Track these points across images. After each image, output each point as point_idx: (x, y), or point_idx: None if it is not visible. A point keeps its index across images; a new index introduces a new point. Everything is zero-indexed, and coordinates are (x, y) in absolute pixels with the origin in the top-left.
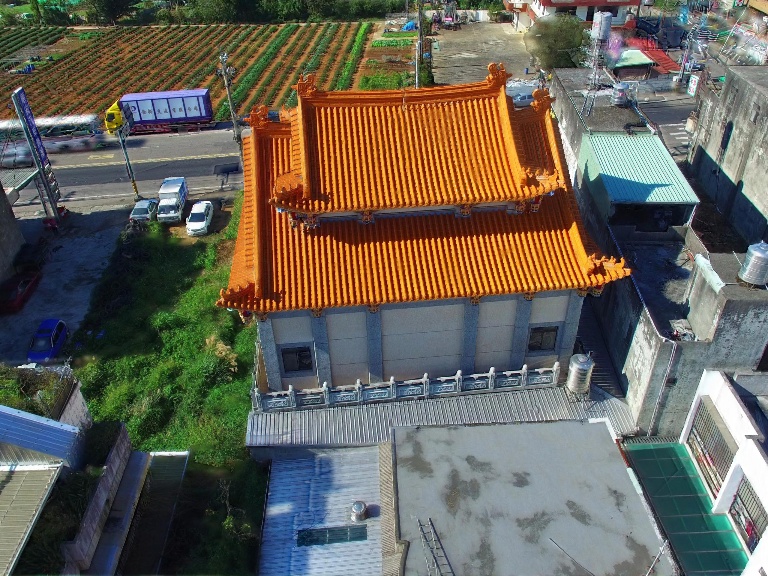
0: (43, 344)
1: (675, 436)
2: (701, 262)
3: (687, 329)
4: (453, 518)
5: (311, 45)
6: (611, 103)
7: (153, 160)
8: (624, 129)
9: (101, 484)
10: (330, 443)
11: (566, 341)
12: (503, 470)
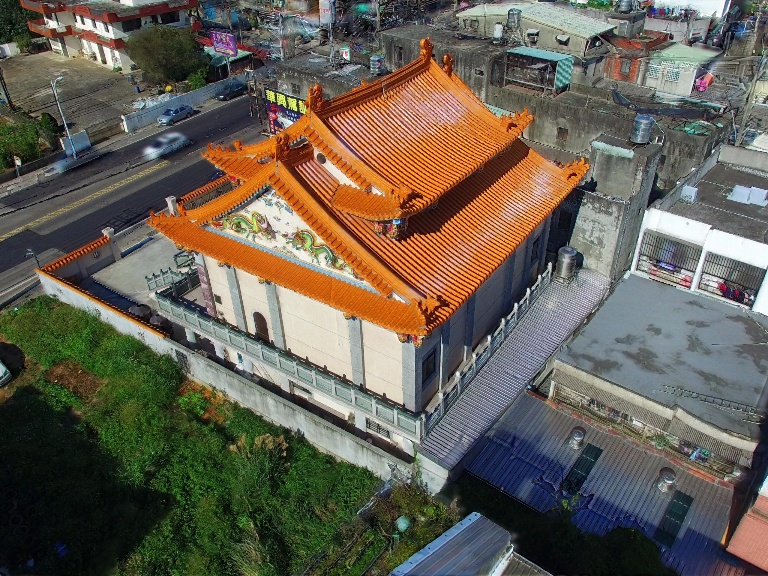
0: None
1: (623, 272)
2: (601, 145)
3: None
4: (668, 375)
5: None
6: (373, 74)
7: None
8: None
9: None
10: (496, 417)
11: None
12: (640, 333)
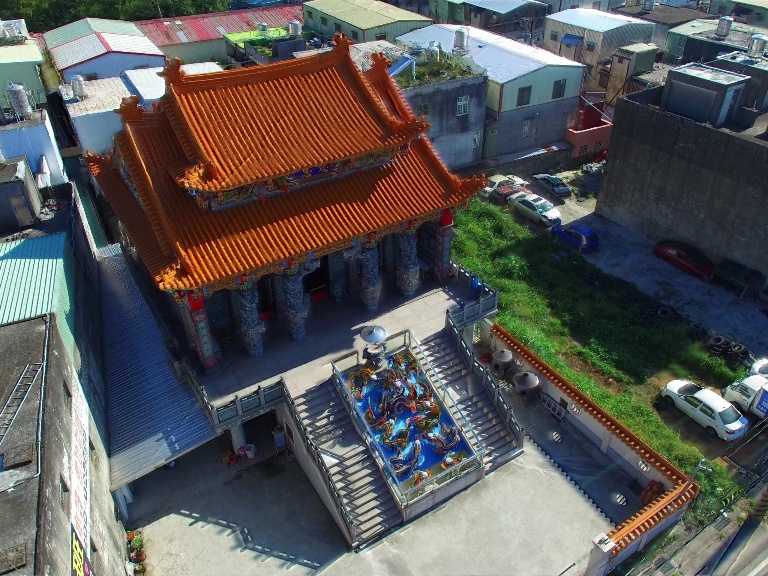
0: None
1: None
2: None
3: (44, 215)
4: None
5: None
6: None
7: None
8: None
9: None
10: None
11: None
12: None
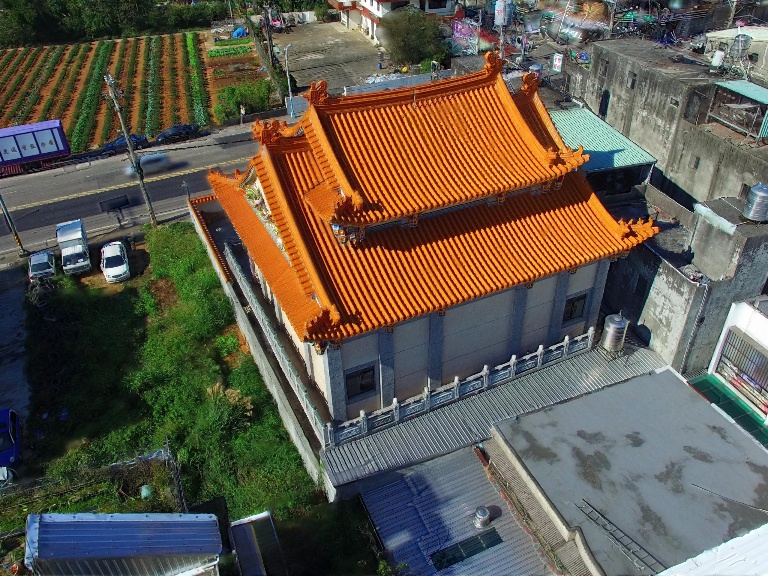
0: (1, 442)
1: (701, 369)
2: (703, 211)
3: (697, 272)
4: (602, 492)
5: (141, 61)
6: None
7: (18, 208)
8: (556, 106)
9: None
10: (418, 459)
11: (594, 306)
12: (615, 435)
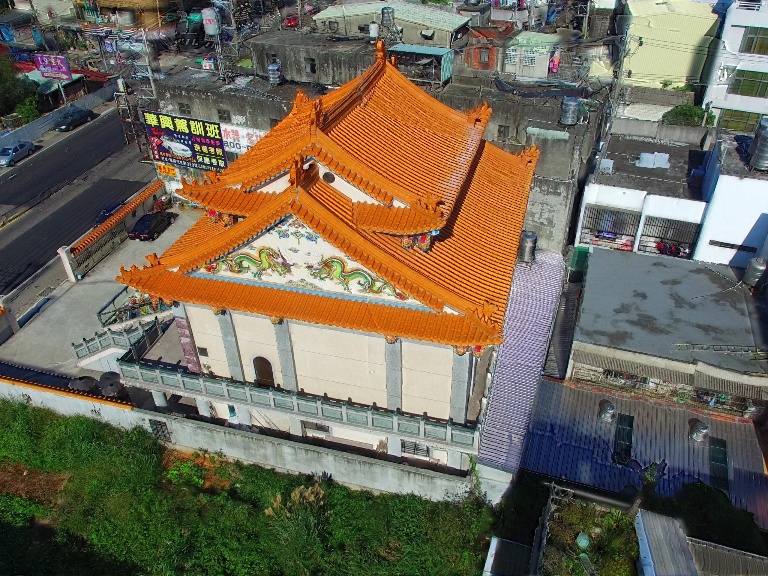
0: None
1: (568, 247)
2: (536, 131)
3: None
4: (673, 333)
5: None
6: (274, 84)
7: None
8: None
9: None
10: None
11: None
12: (630, 300)
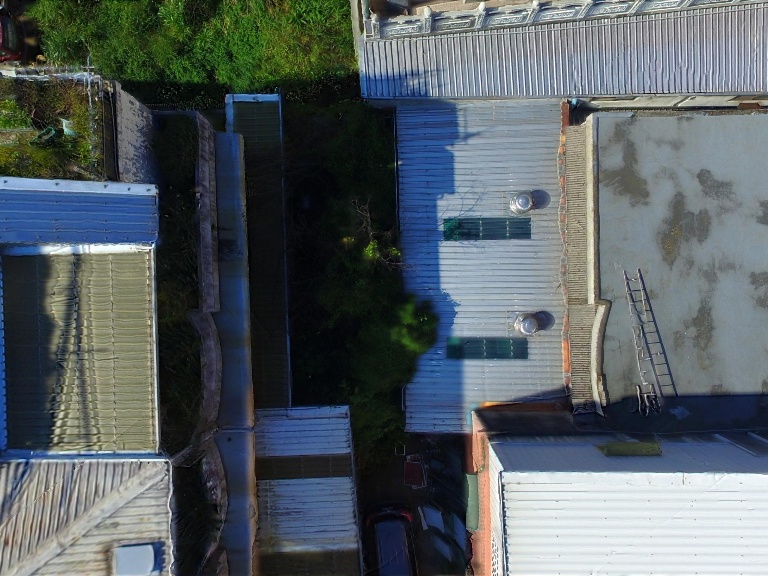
0: None
1: None
2: None
3: None
4: (669, 269)
5: None
6: None
7: None
8: None
9: (201, 220)
10: (481, 95)
11: None
12: (747, 196)
